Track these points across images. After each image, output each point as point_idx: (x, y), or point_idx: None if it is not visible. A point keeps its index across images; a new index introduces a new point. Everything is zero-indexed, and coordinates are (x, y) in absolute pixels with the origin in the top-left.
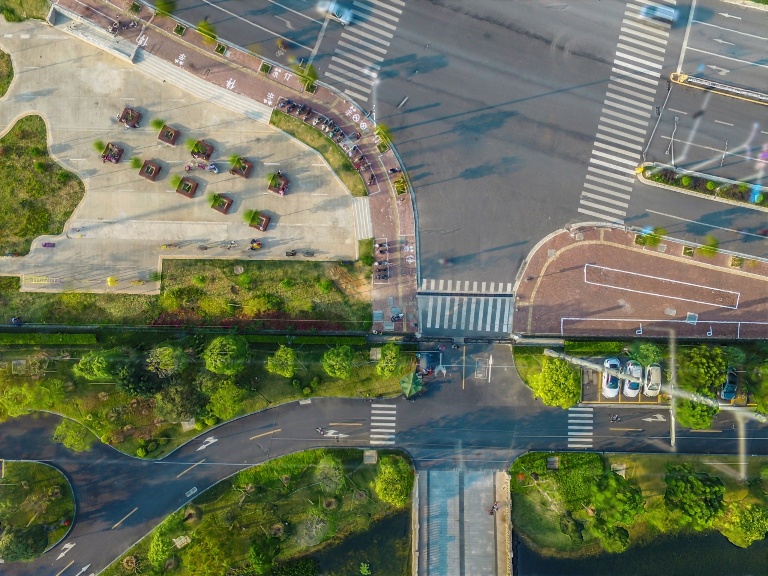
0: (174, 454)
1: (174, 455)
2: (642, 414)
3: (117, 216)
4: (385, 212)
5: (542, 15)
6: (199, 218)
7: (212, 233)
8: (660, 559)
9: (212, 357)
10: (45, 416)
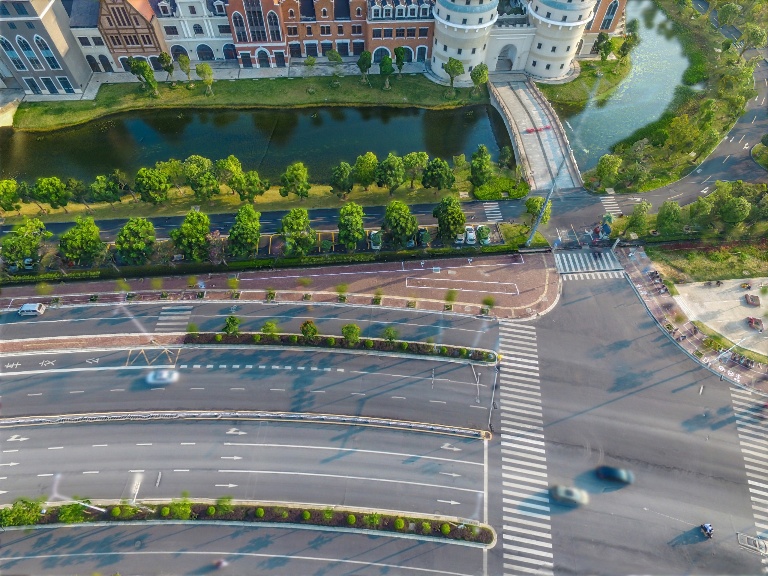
0: None
1: None
2: None
3: None
4: (673, 312)
5: (623, 480)
6: None
7: None
8: None
9: (747, 203)
10: None
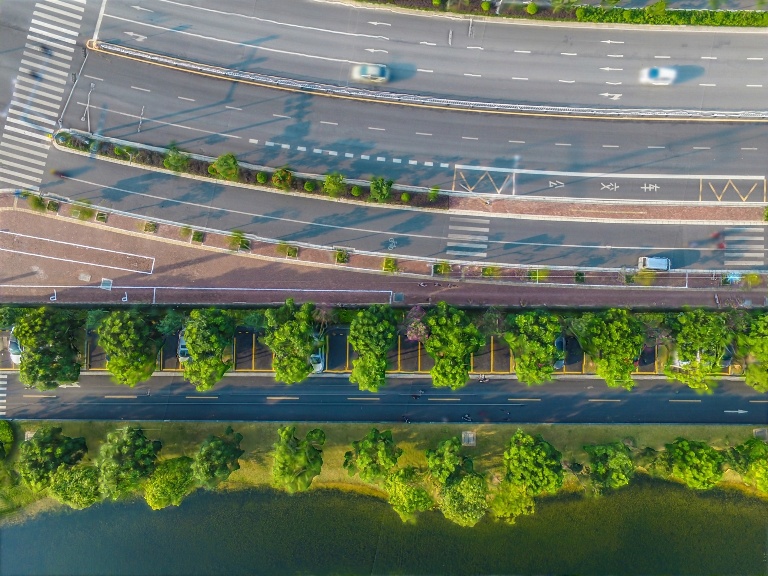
0: None
1: None
2: None
3: None
4: None
5: None
6: None
7: None
8: (86, 527)
9: None
10: None
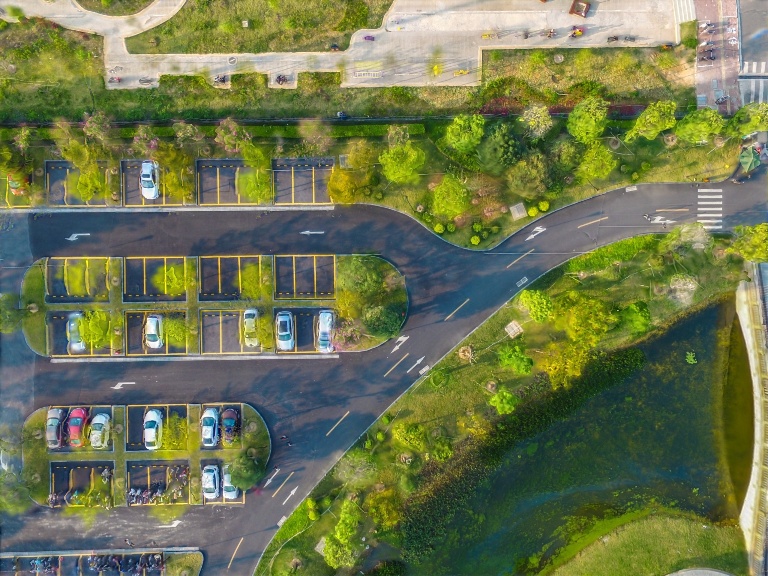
0: (504, 244)
1: (504, 245)
2: None
3: (435, 7)
4: None
5: None
6: (518, 7)
7: (531, 22)
8: None
9: (590, 112)
10: (374, 210)
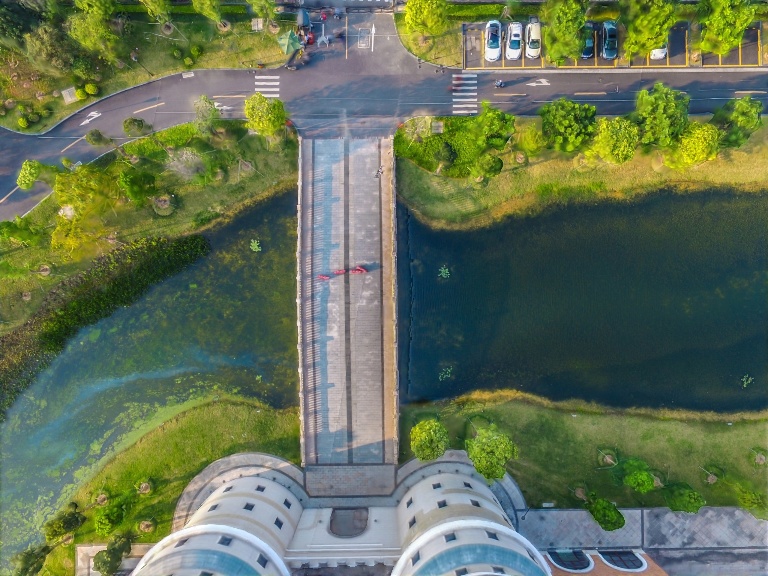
0: (57, 128)
1: (58, 130)
2: (526, 79)
3: None
4: None
5: None
6: None
7: None
8: (550, 229)
9: None
10: None
